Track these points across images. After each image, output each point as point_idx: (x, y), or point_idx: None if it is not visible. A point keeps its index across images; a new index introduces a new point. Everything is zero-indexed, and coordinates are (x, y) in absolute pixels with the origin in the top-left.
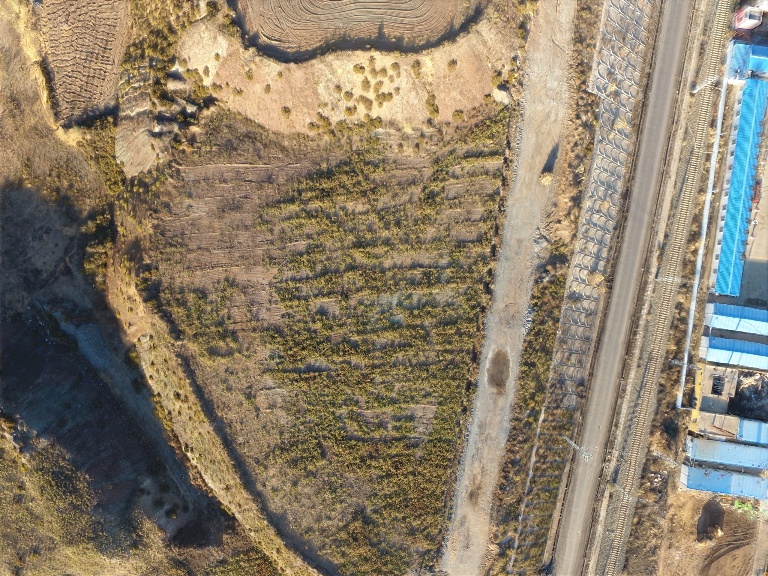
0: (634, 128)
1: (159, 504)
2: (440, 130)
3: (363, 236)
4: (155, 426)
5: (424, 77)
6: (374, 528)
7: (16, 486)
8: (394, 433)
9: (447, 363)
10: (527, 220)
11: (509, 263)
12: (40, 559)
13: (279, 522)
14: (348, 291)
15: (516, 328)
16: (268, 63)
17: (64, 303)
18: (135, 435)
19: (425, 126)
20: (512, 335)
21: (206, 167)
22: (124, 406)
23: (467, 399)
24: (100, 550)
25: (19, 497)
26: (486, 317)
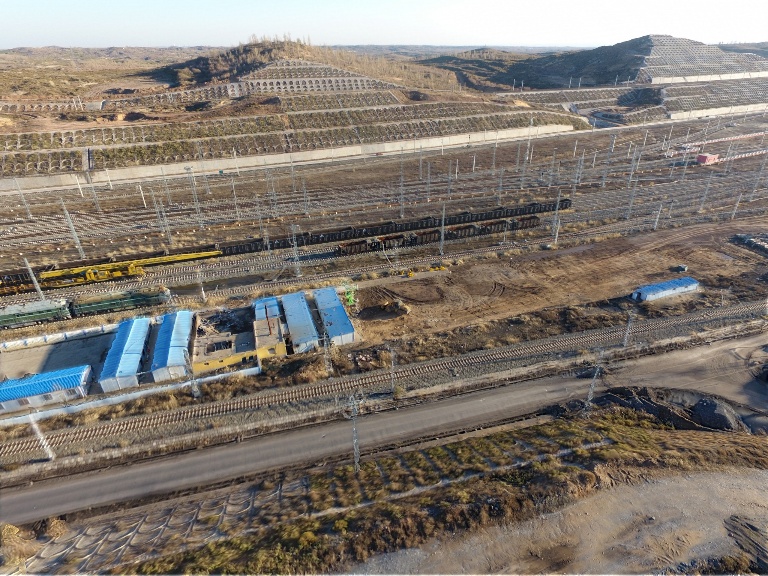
0: None
1: None
2: None
3: None
4: None
5: None
6: None
7: None
8: None
9: None
10: None
11: None
12: None
13: None
14: None
15: None
16: None
17: None
18: None
19: None
20: None
21: None
22: None
23: None
24: None
25: None
26: None
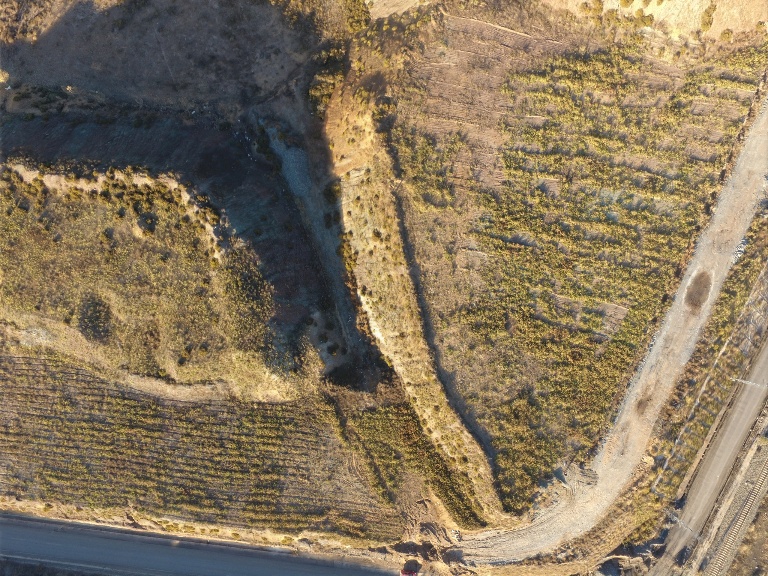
0: None
1: (324, 337)
2: (704, 45)
3: (602, 127)
4: (335, 264)
5: None
6: (537, 410)
7: (201, 278)
8: (582, 324)
9: (650, 271)
10: (764, 154)
11: (736, 191)
12: (205, 354)
13: (446, 380)
14: (573, 176)
15: (726, 255)
16: None
17: (280, 122)
18: (315, 266)
19: (692, 36)
20: (721, 260)
21: (468, 21)
22: (311, 236)
23: (660, 311)
24: (265, 361)
25: (201, 289)
26: (700, 237)
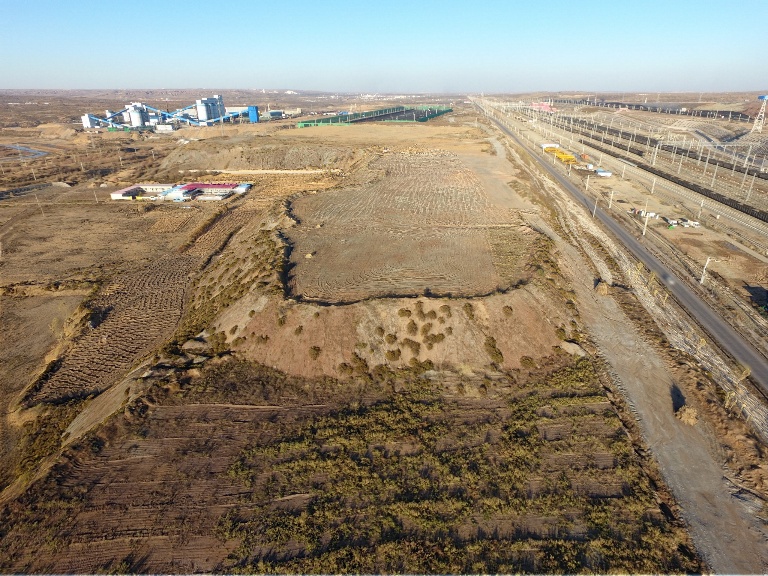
0: (762, 400)
1: None
2: (509, 375)
3: (415, 486)
4: None
5: (478, 320)
6: None
7: None
8: None
9: None
10: (697, 466)
11: (715, 531)
12: None
13: None
14: None
15: None
16: (306, 307)
17: None
18: None
19: (488, 369)
20: None
21: (187, 407)
22: None
23: None
24: None
25: None
26: None
